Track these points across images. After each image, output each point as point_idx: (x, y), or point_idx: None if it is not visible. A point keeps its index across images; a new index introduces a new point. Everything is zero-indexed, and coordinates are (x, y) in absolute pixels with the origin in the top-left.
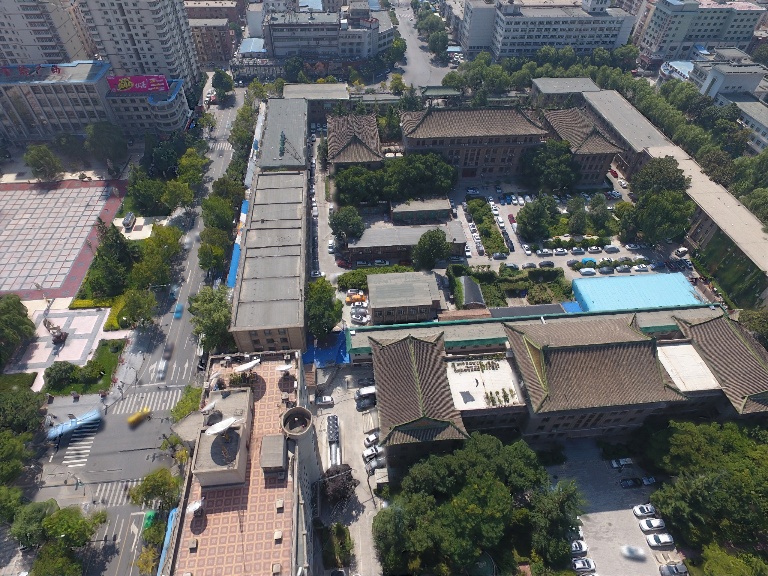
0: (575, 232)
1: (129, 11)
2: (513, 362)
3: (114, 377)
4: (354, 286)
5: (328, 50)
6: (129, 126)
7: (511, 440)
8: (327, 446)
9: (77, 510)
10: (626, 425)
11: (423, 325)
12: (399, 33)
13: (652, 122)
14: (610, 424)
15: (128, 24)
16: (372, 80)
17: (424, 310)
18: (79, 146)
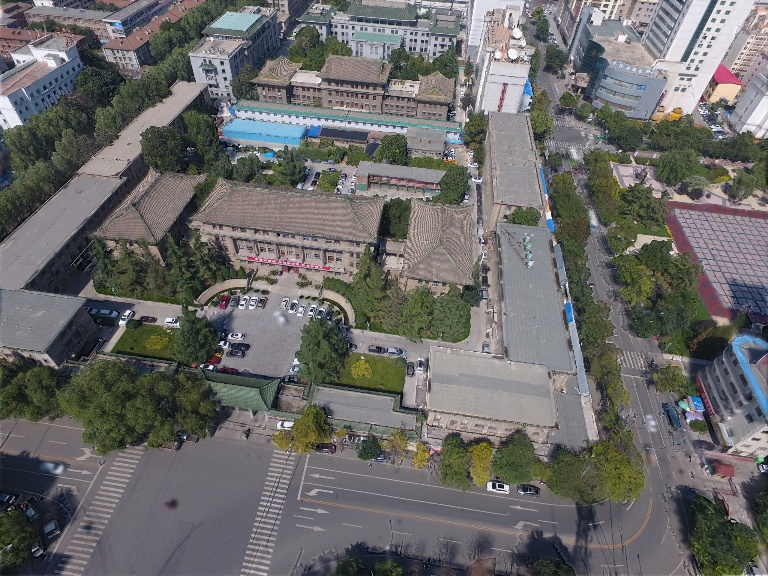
0: None
1: None
2: None
3: None
4: None
5: None
6: None
7: None
8: None
9: (570, 104)
10: None
11: (417, 124)
12: None
13: (4, 234)
14: None
15: None
16: None
17: None
18: None
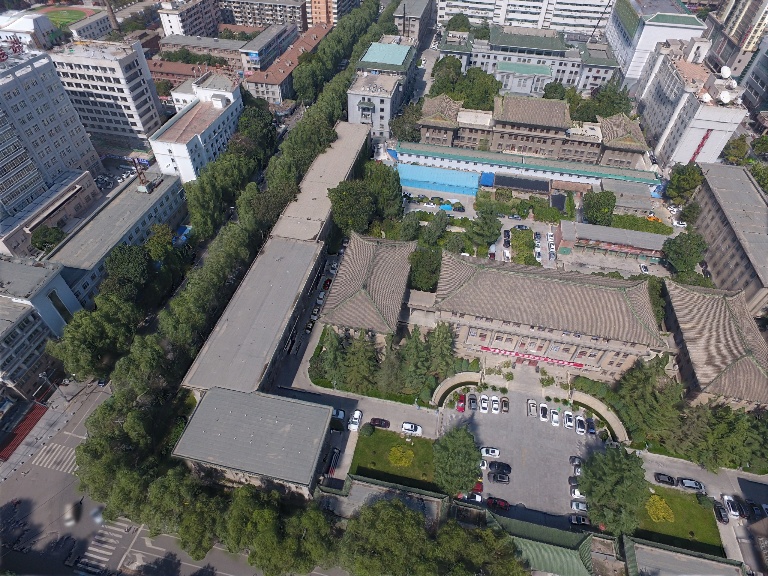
0: None
1: None
2: None
3: None
4: None
5: None
6: None
7: None
8: None
9: None
10: None
11: (607, 174)
12: None
13: None
14: None
15: None
16: None
17: None
18: None
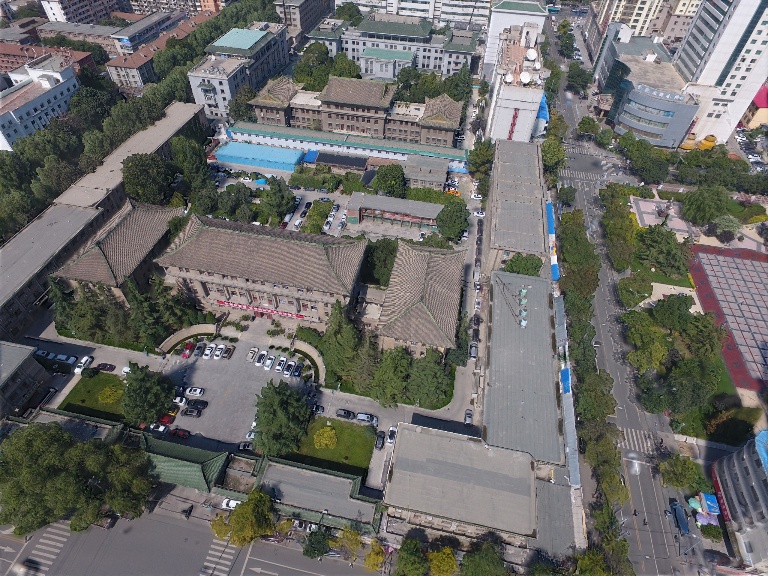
0: None
1: None
2: None
3: None
4: None
5: None
6: None
7: None
8: None
9: (590, 130)
10: None
11: (419, 151)
12: None
13: None
14: None
15: None
16: None
17: None
18: None
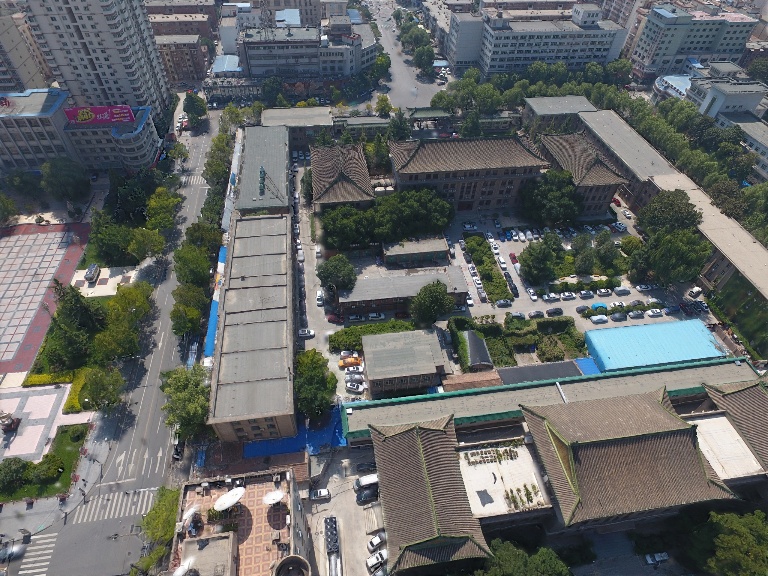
0: (582, 272)
1: (87, 34)
2: (533, 449)
3: (75, 475)
4: (347, 347)
5: (308, 68)
6: (92, 159)
7: (534, 540)
8: (325, 557)
9: None
10: (660, 515)
11: (427, 398)
12: (382, 47)
13: (652, 145)
14: (643, 515)
15: (87, 48)
16: (356, 99)
17: (427, 377)
18: (35, 185)
